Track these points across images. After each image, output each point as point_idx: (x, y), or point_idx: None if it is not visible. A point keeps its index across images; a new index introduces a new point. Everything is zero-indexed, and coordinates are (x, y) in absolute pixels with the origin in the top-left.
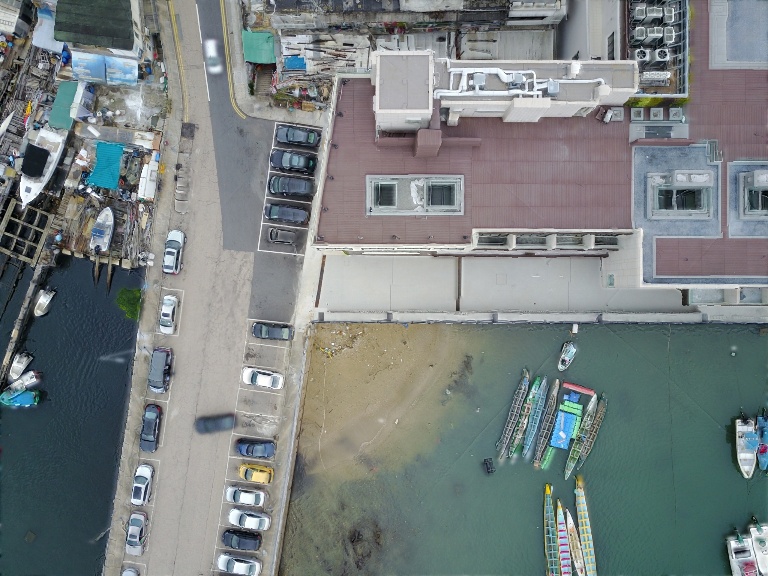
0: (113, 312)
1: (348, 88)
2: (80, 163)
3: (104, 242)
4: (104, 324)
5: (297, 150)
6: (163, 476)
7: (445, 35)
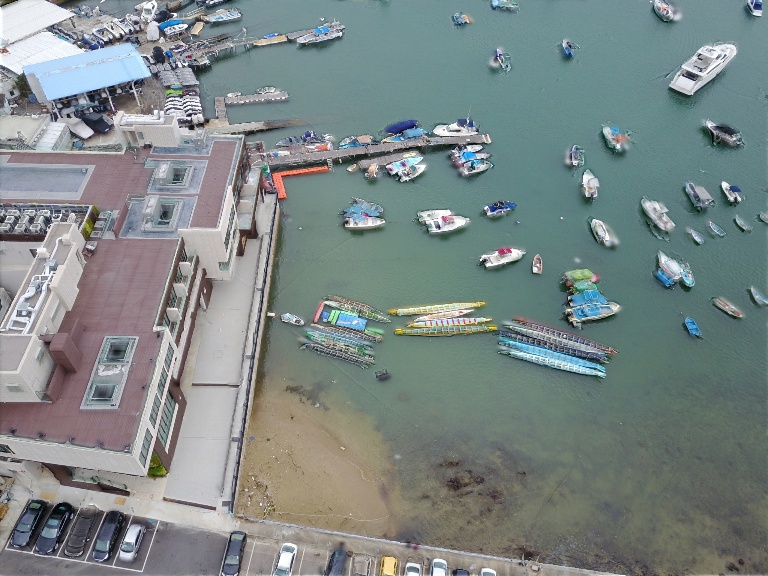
0: None
1: None
2: None
3: None
4: None
5: None
6: None
7: None
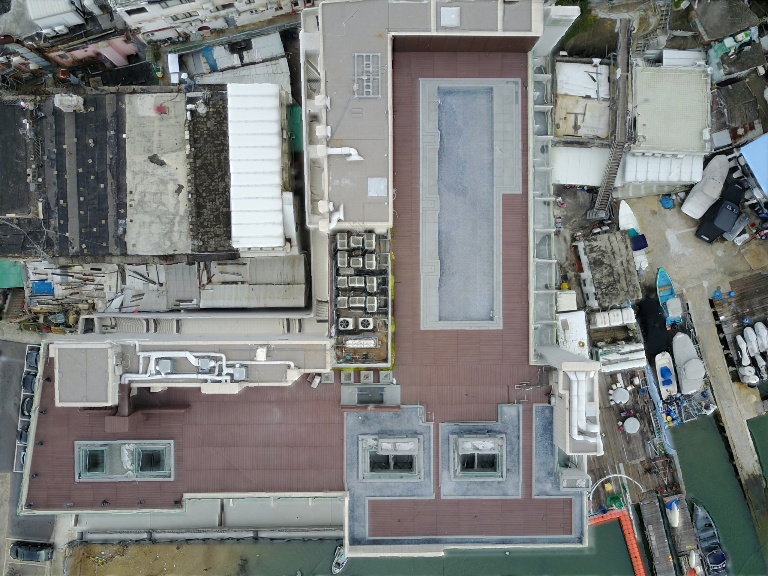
0: None
1: None
2: None
3: None
4: None
5: None
6: None
7: None
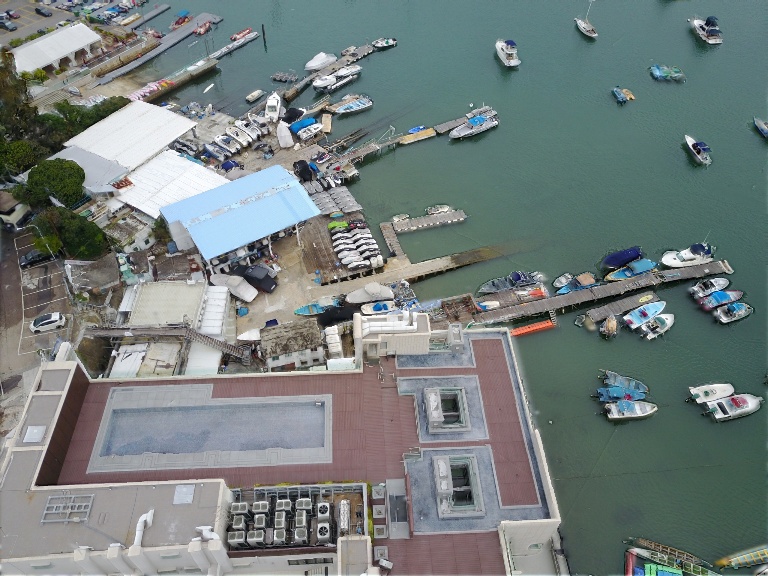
0: None
1: None
2: None
3: None
4: None
5: None
6: None
7: None
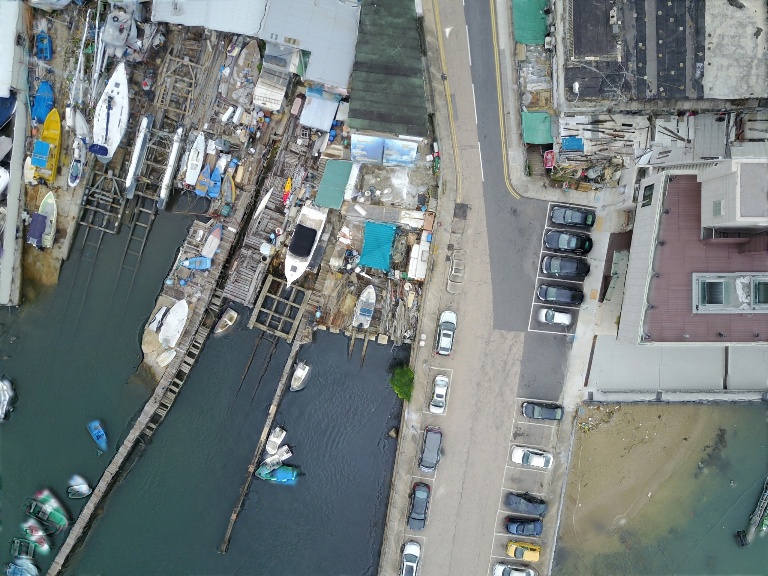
0: (360, 384)
1: (673, 185)
2: (344, 241)
3: (365, 319)
4: (351, 396)
5: (570, 230)
6: (428, 553)
7: (725, 115)
